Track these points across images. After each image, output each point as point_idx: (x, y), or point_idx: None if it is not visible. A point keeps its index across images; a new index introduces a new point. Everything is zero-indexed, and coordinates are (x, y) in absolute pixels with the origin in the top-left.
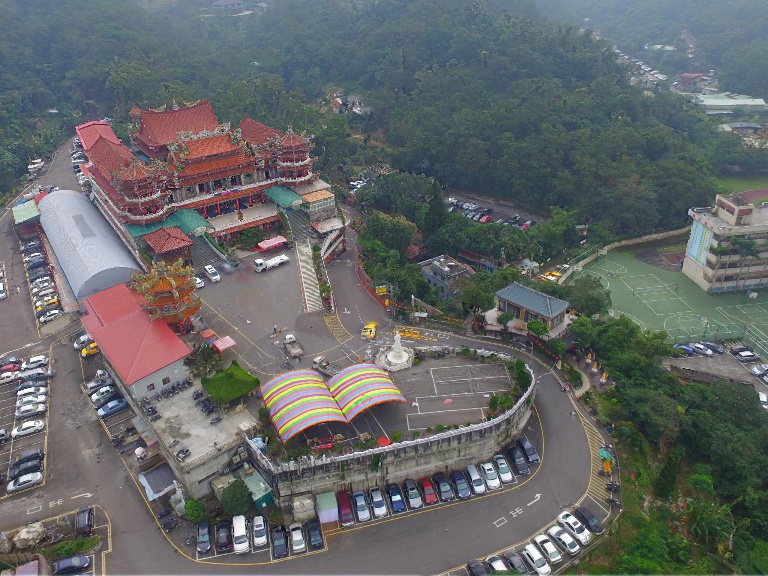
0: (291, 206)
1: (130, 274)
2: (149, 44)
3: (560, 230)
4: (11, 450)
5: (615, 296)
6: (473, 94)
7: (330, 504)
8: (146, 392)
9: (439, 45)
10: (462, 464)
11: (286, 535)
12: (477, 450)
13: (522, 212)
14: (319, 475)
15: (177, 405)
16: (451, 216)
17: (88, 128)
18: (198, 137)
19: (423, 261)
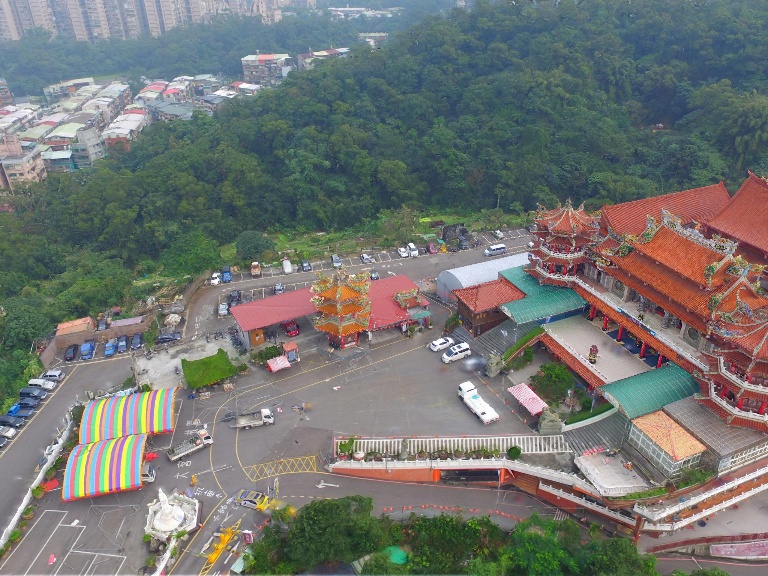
0: None
1: None
2: None
3: None
4: None
5: None
6: None
7: None
8: None
9: None
10: None
11: None
12: None
13: None
14: None
15: None
16: None
17: None
18: (685, 233)
19: None
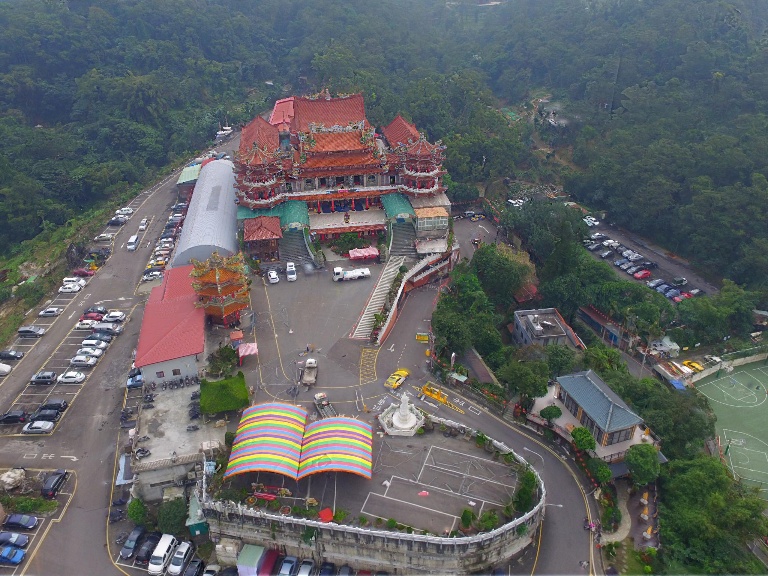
0: (397, 218)
1: (223, 254)
2: (367, 29)
3: (723, 312)
4: (50, 393)
5: (765, 417)
6: (684, 122)
7: (250, 560)
8: (155, 377)
9: (670, 59)
10: (414, 573)
11: (199, 574)
12: (434, 564)
13: (695, 276)
14: (249, 525)
15: (174, 399)
16: (590, 263)
17: (284, 103)
18: (329, 131)
19: (524, 310)
